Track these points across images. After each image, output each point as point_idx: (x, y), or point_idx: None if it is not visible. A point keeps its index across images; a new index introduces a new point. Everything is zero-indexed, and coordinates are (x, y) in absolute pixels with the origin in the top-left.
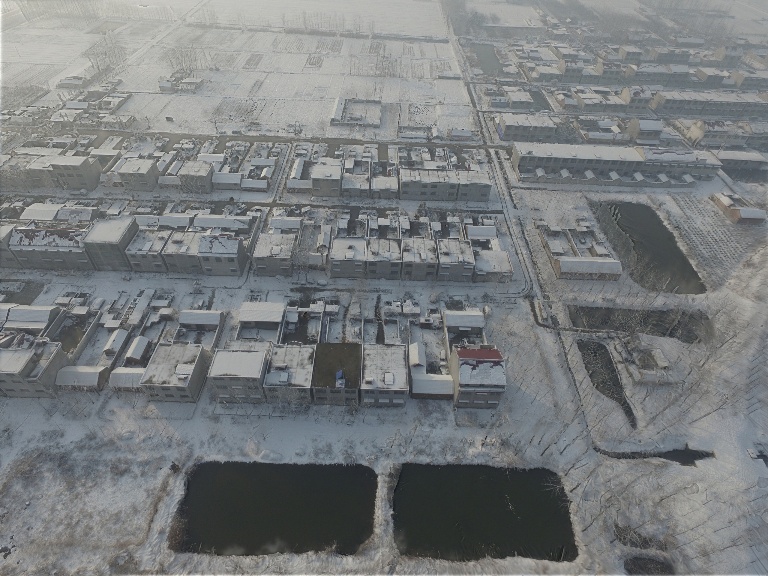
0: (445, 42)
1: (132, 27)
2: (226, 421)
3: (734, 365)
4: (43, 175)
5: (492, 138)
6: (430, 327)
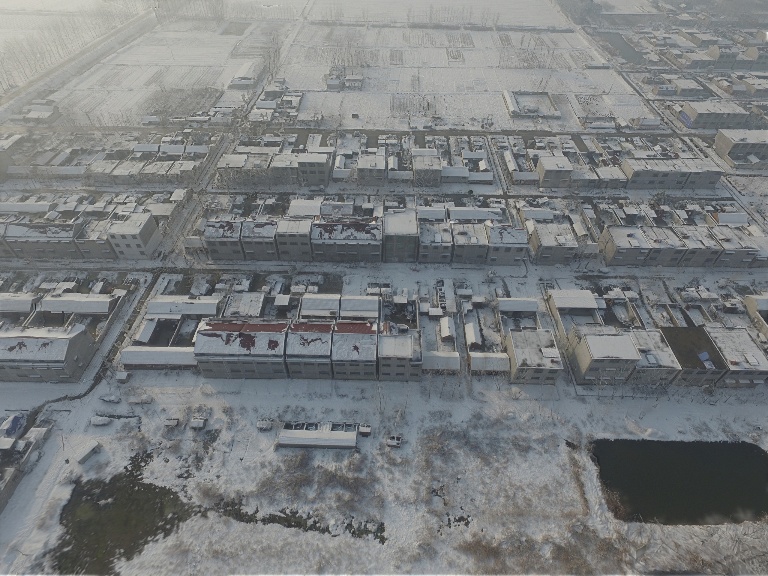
0: (571, 32)
1: (261, 27)
2: (593, 401)
3: None
4: (285, 172)
5: (682, 126)
6: (733, 311)
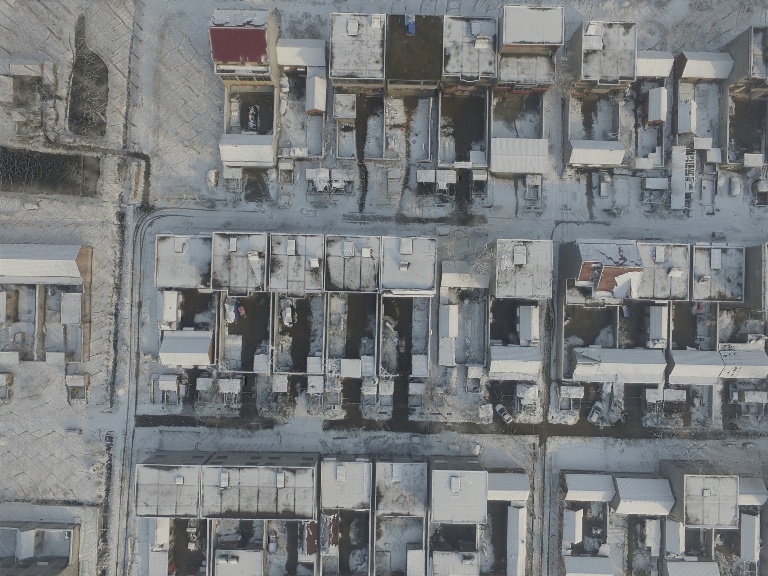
0: None
1: None
2: None
3: None
4: None
5: None
6: None
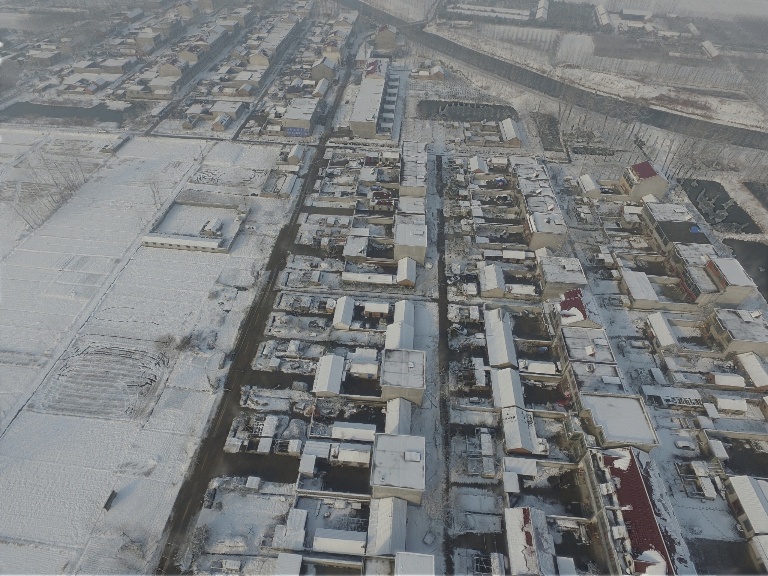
0: None
1: None
2: (743, 309)
3: (579, 112)
4: None
5: (312, 138)
6: None
